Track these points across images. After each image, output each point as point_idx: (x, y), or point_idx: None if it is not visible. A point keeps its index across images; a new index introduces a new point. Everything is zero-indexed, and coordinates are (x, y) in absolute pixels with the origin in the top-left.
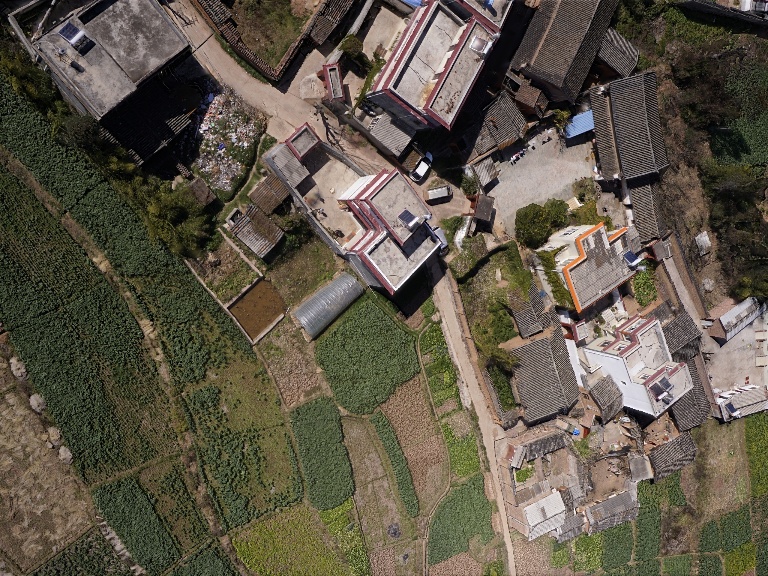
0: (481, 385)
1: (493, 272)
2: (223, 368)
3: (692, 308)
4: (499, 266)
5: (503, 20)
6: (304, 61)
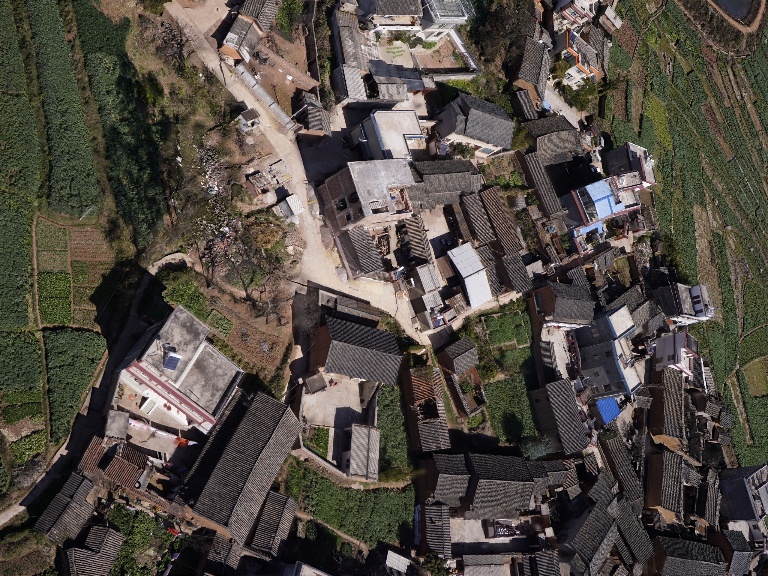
0: None
1: None
2: None
3: None
4: None
5: None
6: None
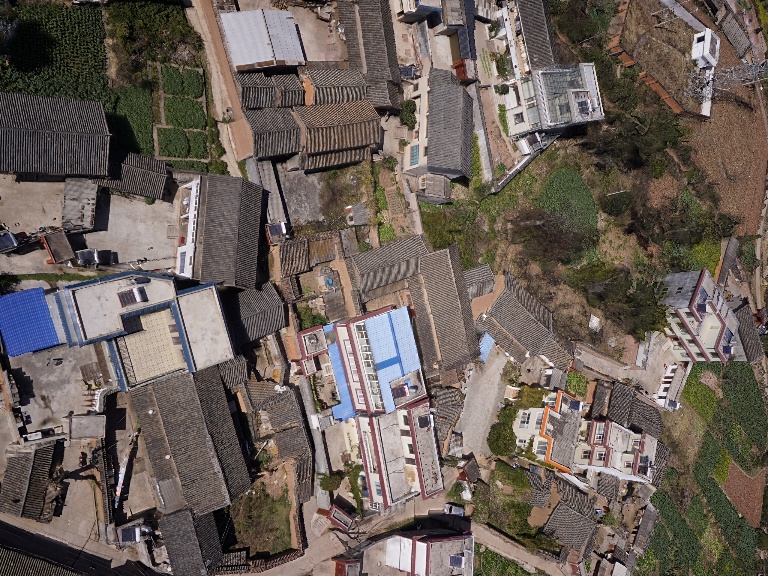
0: (534, 554)
1: (495, 486)
2: None
3: (612, 366)
4: (496, 478)
5: (424, 387)
6: (303, 514)
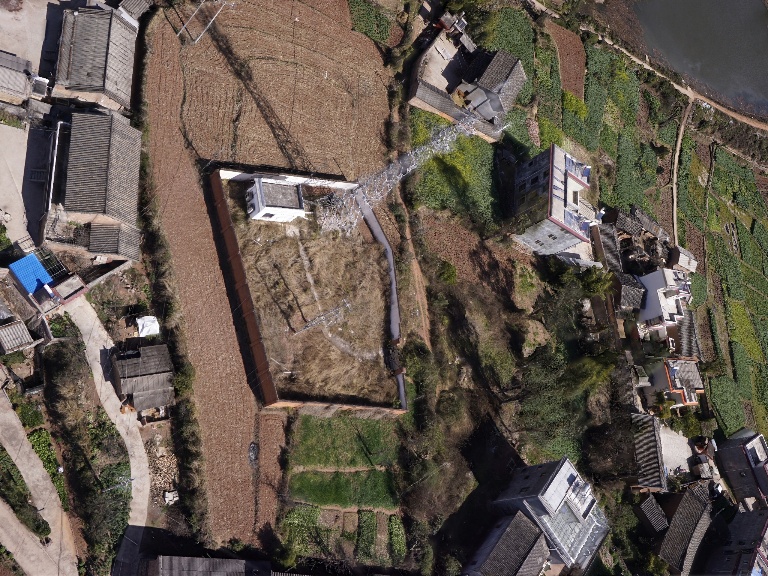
0: None
1: None
2: (767, 437)
3: None
4: None
5: None
6: None
